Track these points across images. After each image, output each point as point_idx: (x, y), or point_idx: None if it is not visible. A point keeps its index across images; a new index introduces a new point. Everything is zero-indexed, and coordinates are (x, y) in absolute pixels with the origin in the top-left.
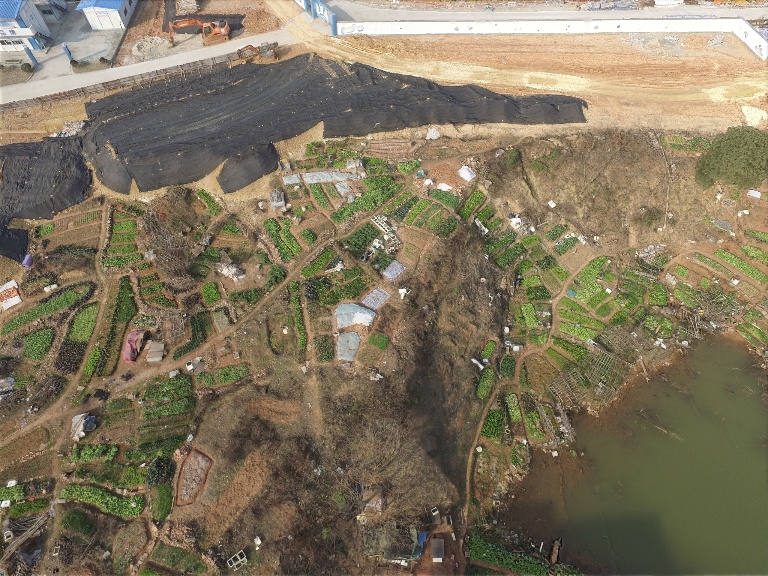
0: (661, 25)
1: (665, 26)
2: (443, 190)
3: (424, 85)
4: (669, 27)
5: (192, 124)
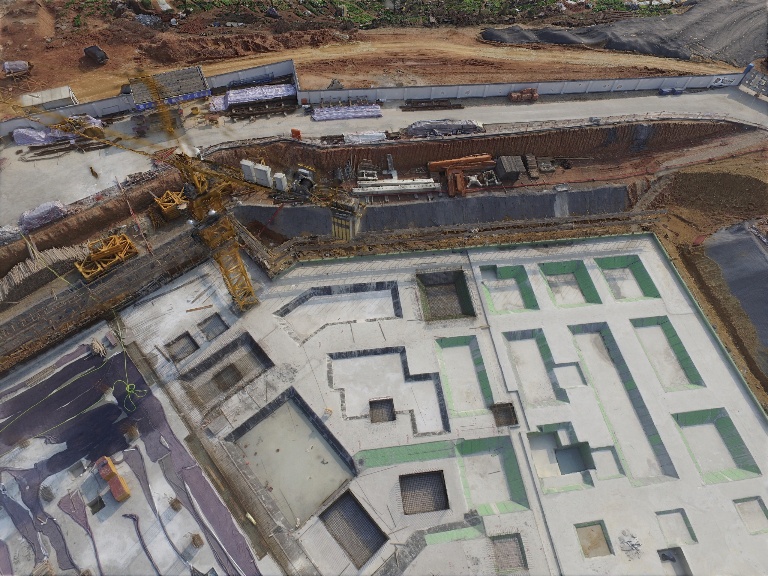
0: (394, 93)
1: (389, 95)
2: (571, 1)
3: (620, 35)
4: (383, 96)
5: (761, 15)
